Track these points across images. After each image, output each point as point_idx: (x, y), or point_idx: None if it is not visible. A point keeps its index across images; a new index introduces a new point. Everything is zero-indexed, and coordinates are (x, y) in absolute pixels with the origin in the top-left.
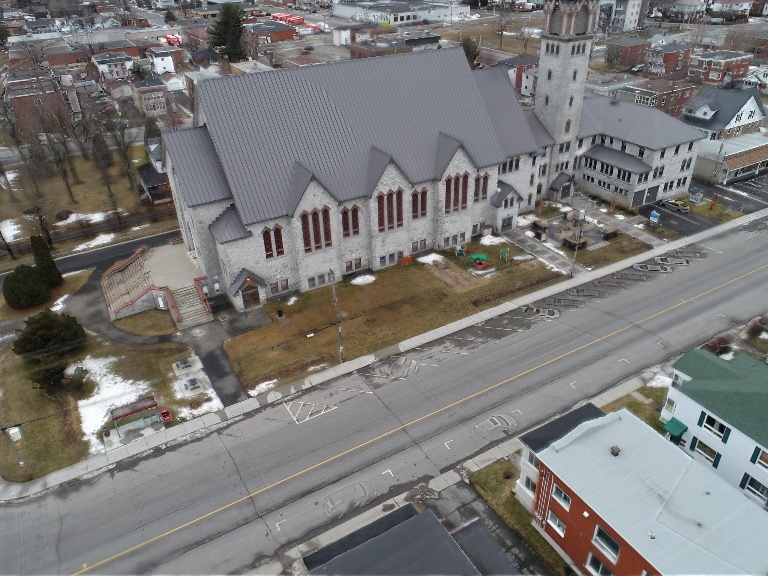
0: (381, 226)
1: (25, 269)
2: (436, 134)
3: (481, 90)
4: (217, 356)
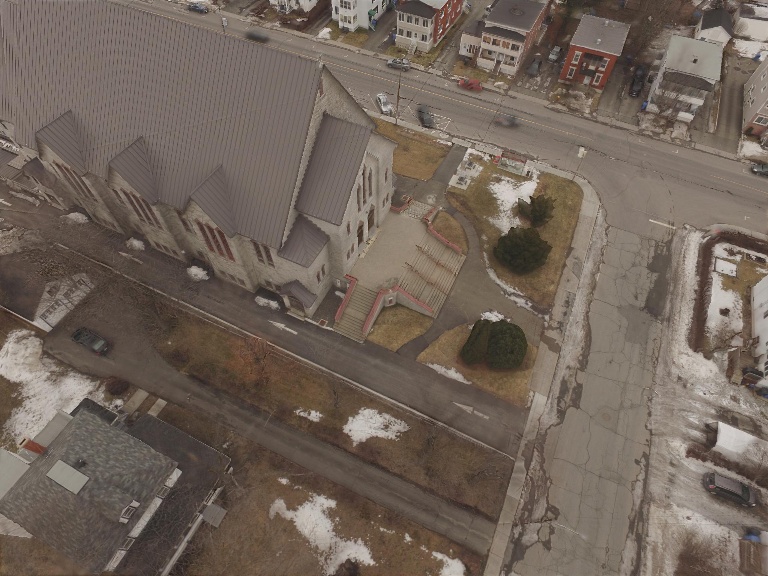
0: None
1: (505, 327)
2: None
3: None
4: (440, 175)
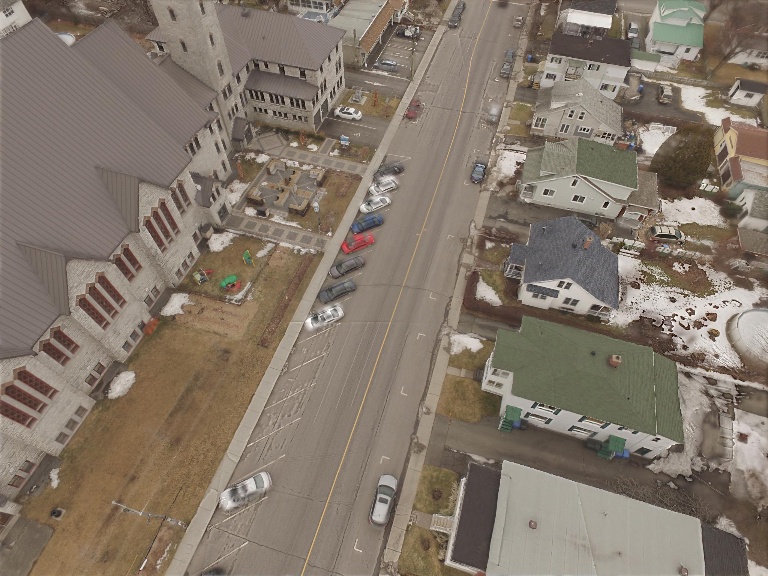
0: (102, 322)
1: None
2: (92, 172)
3: (103, 70)
4: None
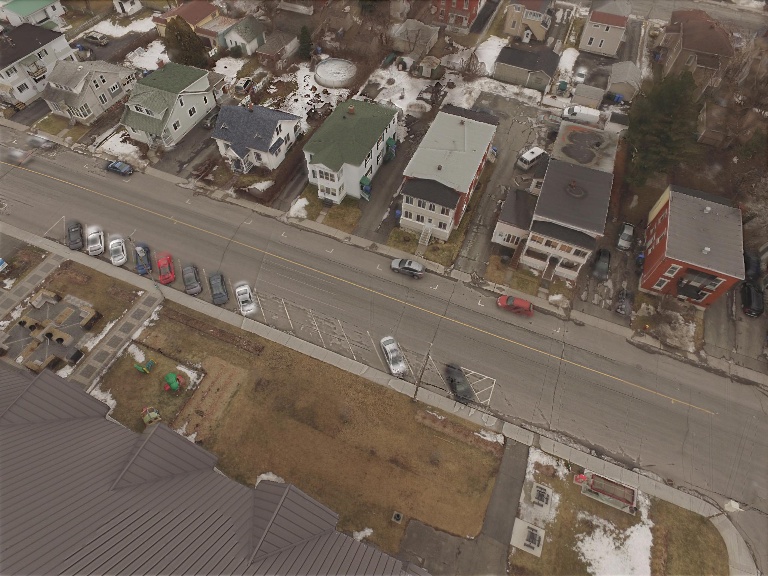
0: None
1: None
2: (1, 430)
3: None
4: (495, 521)
